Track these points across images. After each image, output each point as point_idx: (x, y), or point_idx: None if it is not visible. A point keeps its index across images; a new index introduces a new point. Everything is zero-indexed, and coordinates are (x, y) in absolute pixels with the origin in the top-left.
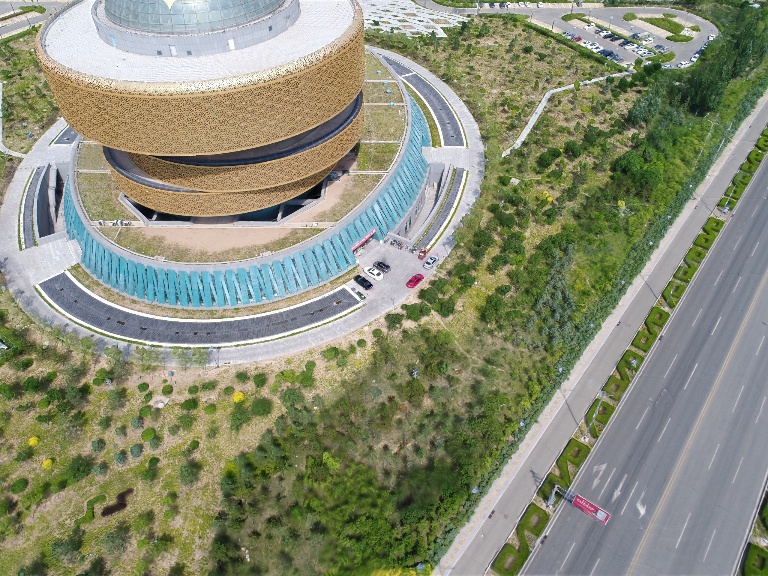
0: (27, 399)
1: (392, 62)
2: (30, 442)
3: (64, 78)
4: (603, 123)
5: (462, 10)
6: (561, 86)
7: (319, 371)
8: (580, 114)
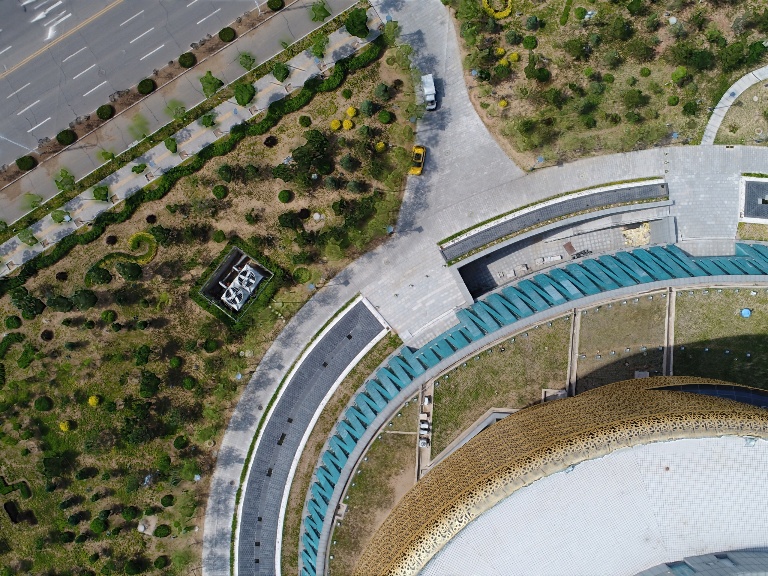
0: (156, 368)
1: None
2: (90, 399)
3: (385, 575)
4: None
5: None
6: None
7: None
8: None
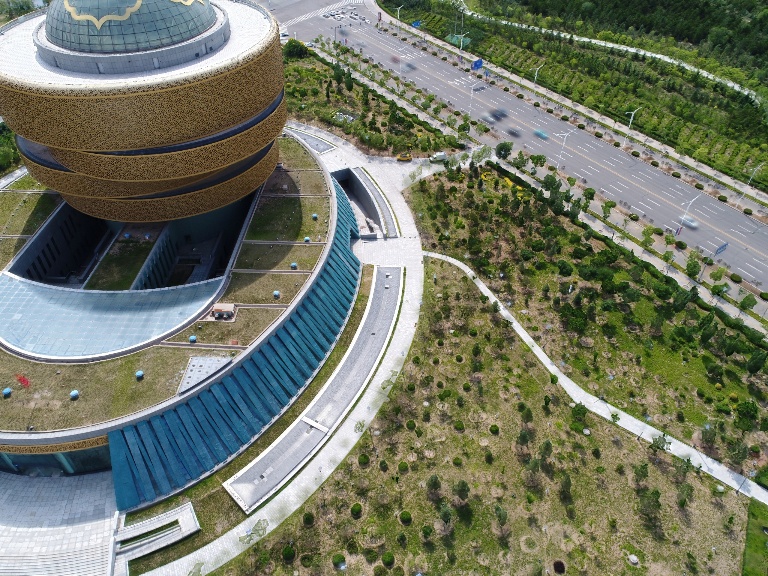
0: (309, 101)
1: None
2: None
3: None
4: None
5: None
6: None
7: None
8: None
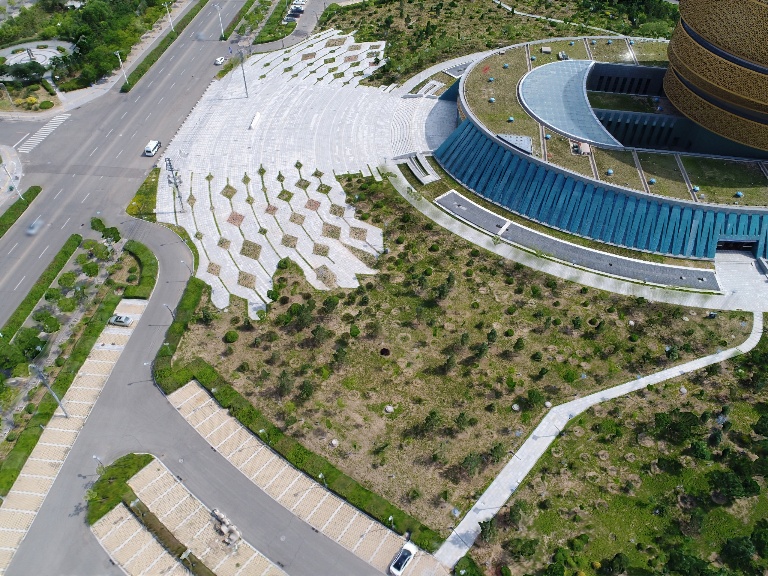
0: None
1: (462, 67)
2: None
3: None
4: (563, 3)
5: (299, 31)
6: (503, 8)
7: None
8: (553, 7)
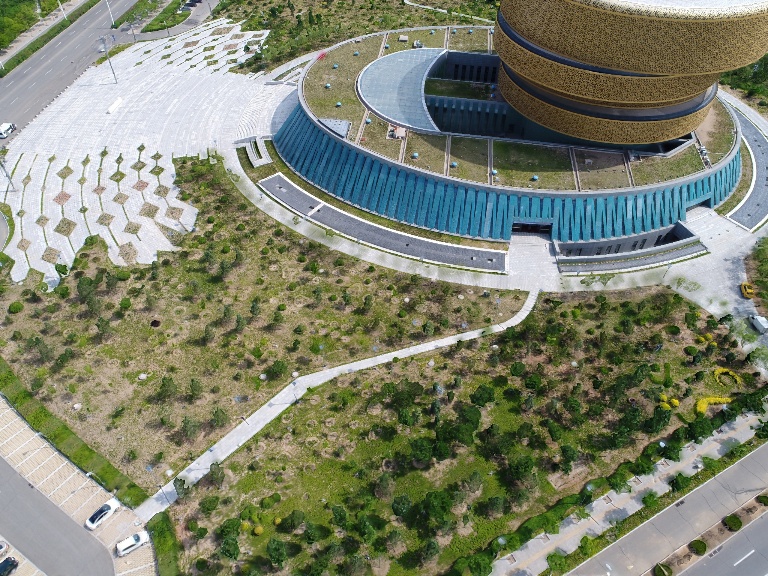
0: None
1: None
2: None
3: None
4: None
5: (191, 20)
6: None
7: (765, 101)
8: None
